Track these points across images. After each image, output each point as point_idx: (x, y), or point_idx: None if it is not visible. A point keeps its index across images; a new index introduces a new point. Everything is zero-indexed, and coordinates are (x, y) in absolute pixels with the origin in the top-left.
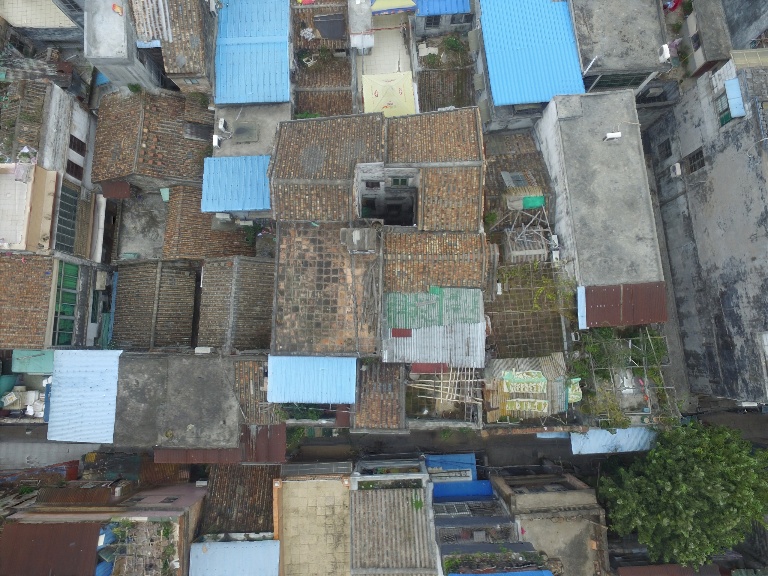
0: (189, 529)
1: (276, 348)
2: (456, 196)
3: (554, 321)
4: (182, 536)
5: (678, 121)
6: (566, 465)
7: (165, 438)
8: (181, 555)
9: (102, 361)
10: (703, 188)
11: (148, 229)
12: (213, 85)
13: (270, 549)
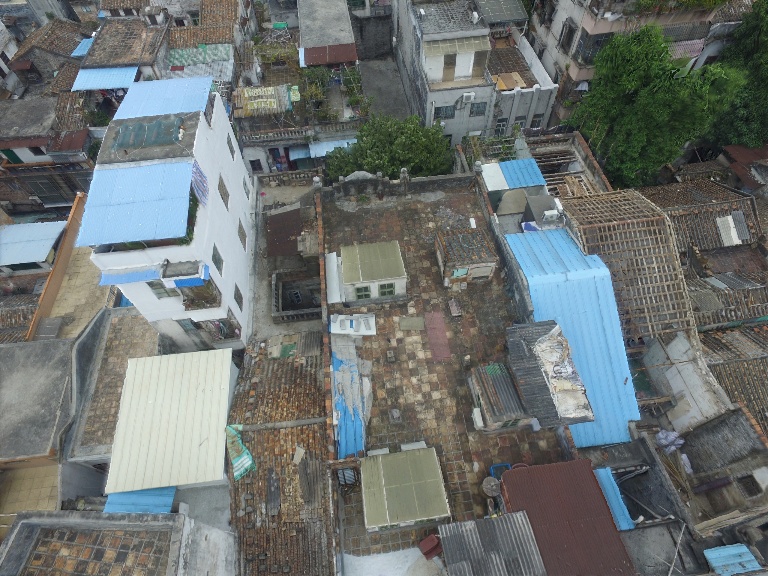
0: None
1: None
2: (222, 8)
3: None
4: None
5: (393, 21)
6: None
7: None
8: None
9: None
10: None
11: None
12: (99, 10)
13: (58, 225)
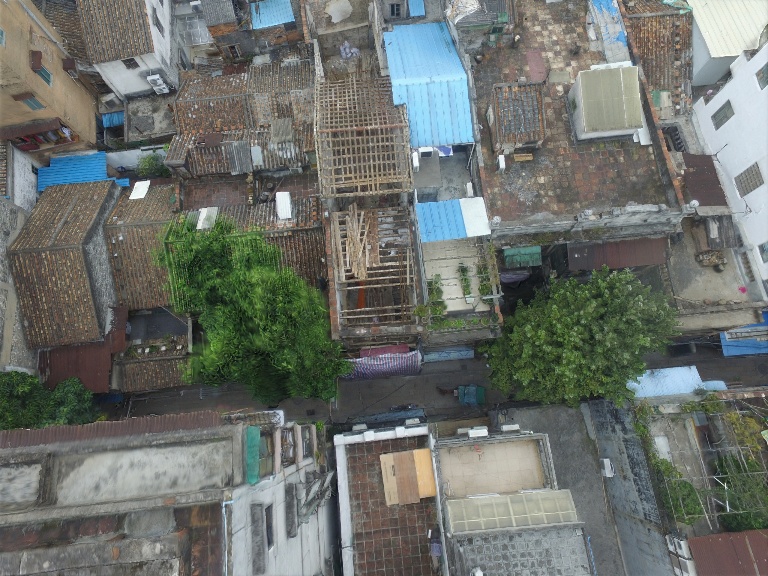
0: None
1: None
2: None
3: None
4: None
5: None
6: None
7: None
8: None
9: None
10: None
11: None
12: None
13: None
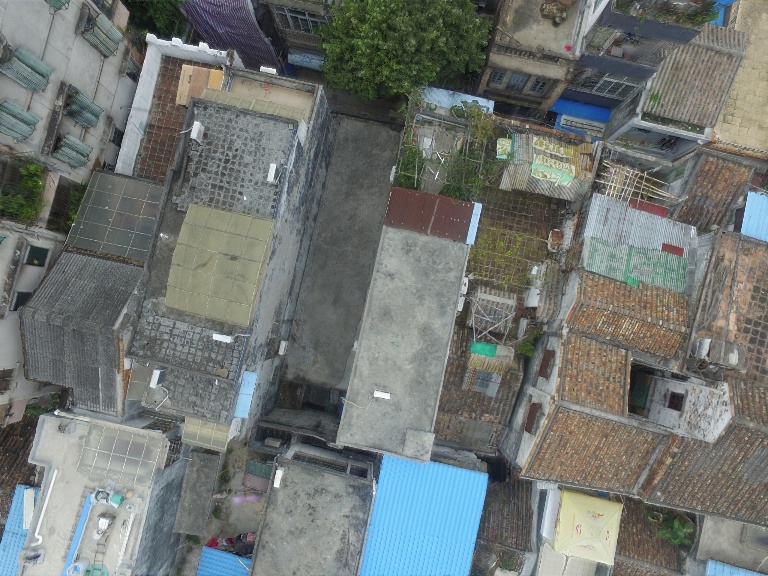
0: None
1: None
2: (589, 376)
3: None
4: None
5: None
6: None
7: None
8: None
9: None
10: None
11: None
12: None
13: None
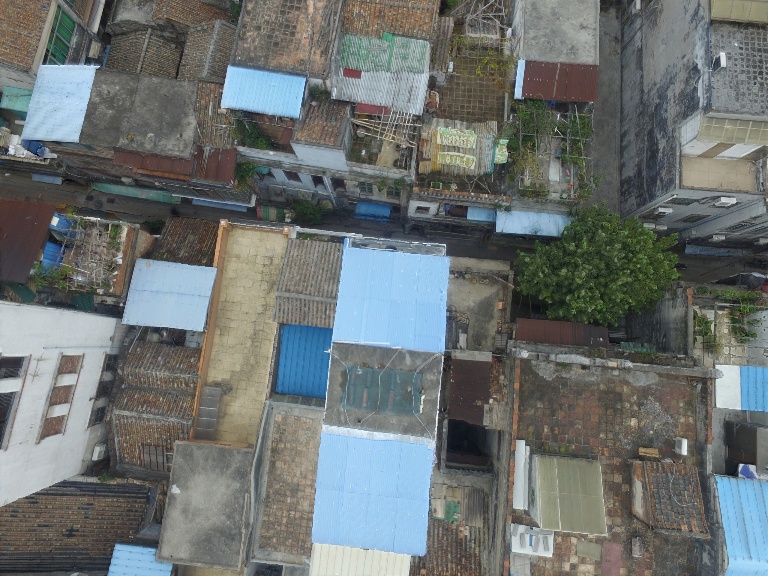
0: (137, 248)
1: (235, 58)
2: None
3: (498, 110)
4: (129, 246)
5: None
6: None
7: (126, 142)
8: (125, 261)
9: (80, 74)
10: (655, 14)
11: (144, 3)
12: None
13: (207, 273)
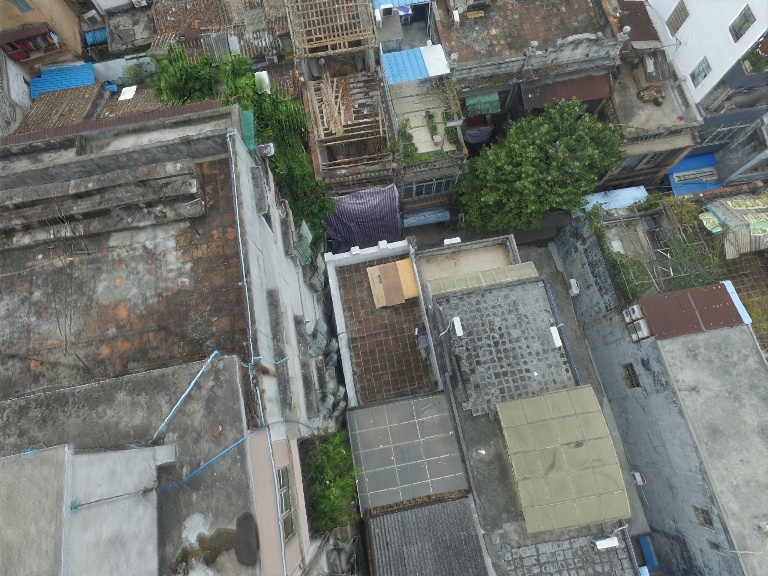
0: None
1: None
2: None
3: None
4: None
5: None
6: (555, 209)
7: None
8: None
9: None
10: None
11: None
12: None
13: None
